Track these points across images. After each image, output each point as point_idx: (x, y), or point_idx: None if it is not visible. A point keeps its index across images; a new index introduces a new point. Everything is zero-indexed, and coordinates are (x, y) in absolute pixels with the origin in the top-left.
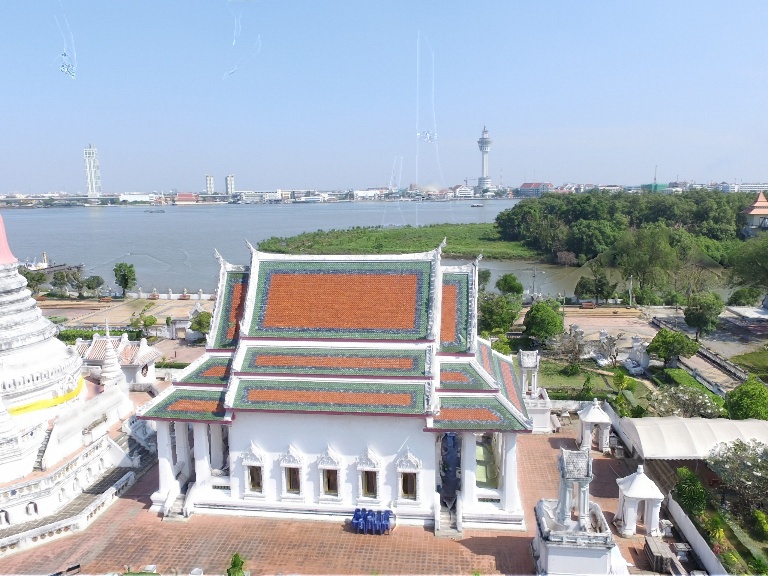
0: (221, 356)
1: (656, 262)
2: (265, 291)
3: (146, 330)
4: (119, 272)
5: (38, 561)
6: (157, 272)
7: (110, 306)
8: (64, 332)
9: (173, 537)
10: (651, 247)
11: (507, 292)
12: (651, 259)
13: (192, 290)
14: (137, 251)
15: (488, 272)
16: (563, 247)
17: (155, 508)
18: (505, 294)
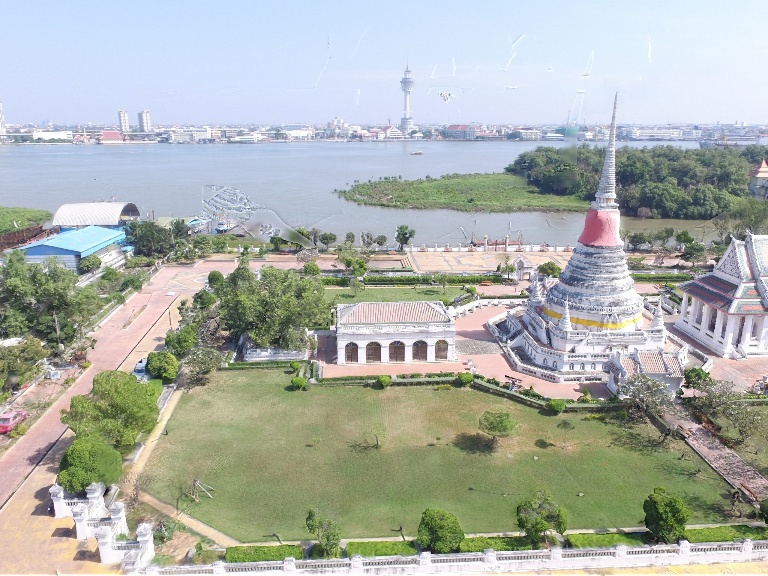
0: (750, 285)
1: (765, 221)
2: (760, 253)
3: (508, 274)
4: (402, 232)
5: (722, 375)
6: (368, 229)
7: (405, 258)
8: (451, 277)
9: (756, 365)
10: (763, 211)
11: (682, 243)
12: (763, 219)
13: (414, 243)
14: (307, 209)
15: (673, 229)
16: (637, 203)
17: (726, 356)
18: (680, 244)
